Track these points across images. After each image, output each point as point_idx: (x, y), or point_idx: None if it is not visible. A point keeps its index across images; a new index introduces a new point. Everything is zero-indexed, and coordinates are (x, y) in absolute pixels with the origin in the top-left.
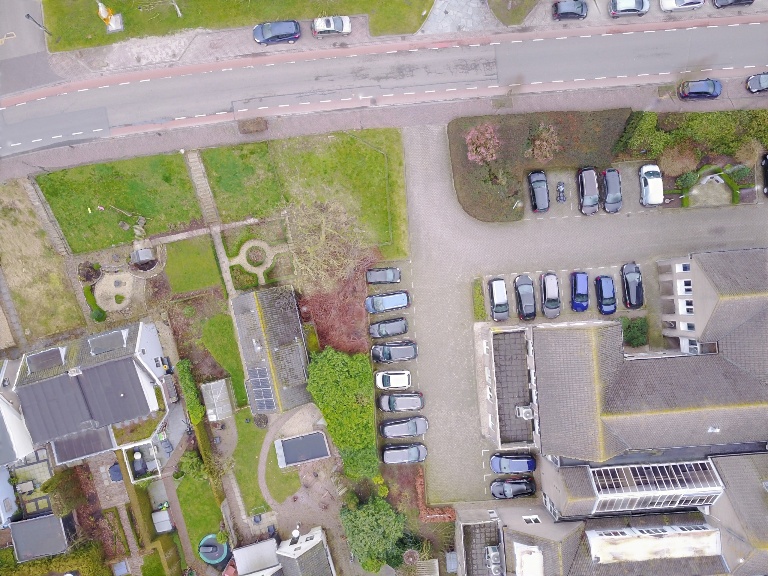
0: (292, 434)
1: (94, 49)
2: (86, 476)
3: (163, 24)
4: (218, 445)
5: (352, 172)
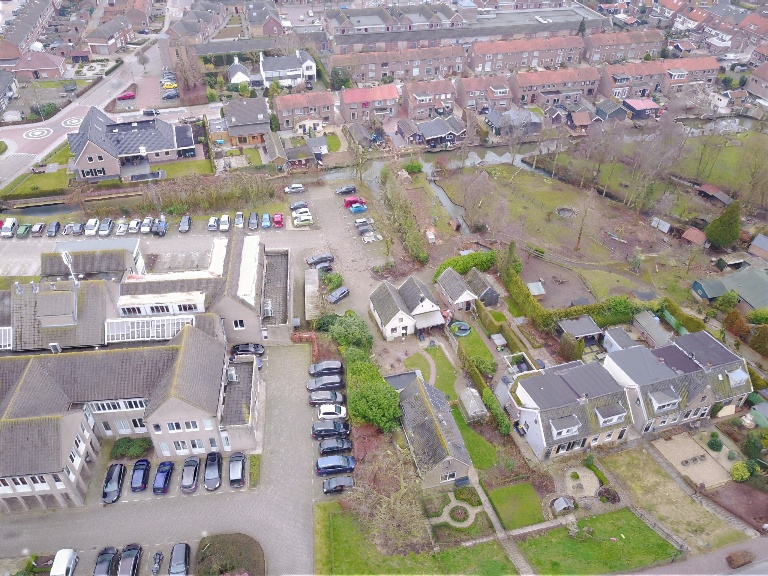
0: None
1: None
2: None
3: None
4: None
5: (369, 575)
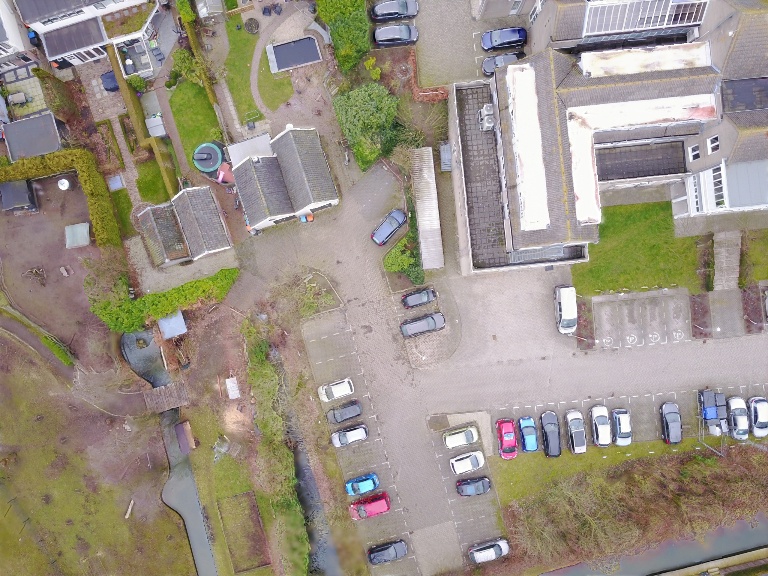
0: (283, 40)
1: None
2: (78, 89)
3: None
4: (210, 54)
5: None
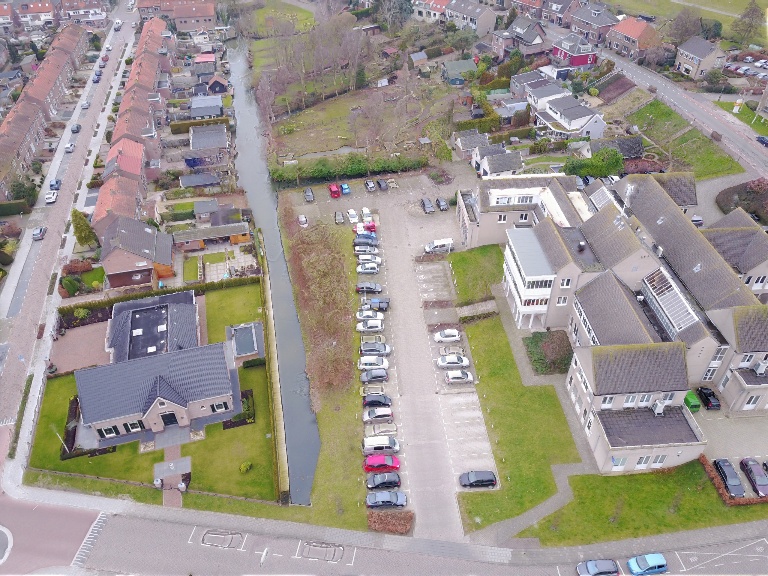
0: None
1: (720, 108)
2: None
3: (745, 120)
4: None
5: None
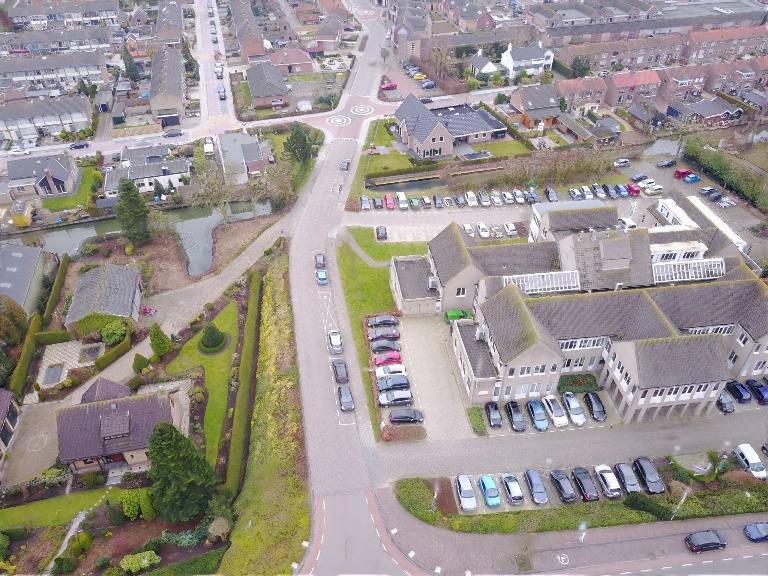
0: None
1: None
2: None
3: None
4: None
5: None
